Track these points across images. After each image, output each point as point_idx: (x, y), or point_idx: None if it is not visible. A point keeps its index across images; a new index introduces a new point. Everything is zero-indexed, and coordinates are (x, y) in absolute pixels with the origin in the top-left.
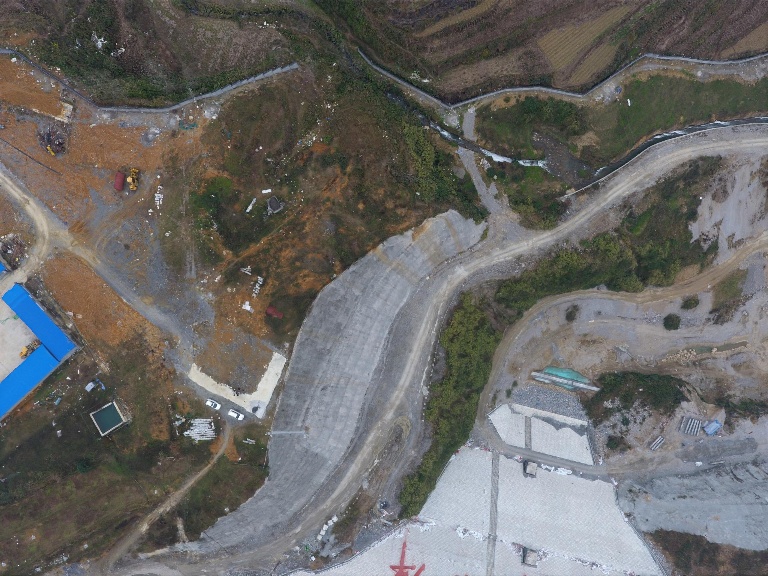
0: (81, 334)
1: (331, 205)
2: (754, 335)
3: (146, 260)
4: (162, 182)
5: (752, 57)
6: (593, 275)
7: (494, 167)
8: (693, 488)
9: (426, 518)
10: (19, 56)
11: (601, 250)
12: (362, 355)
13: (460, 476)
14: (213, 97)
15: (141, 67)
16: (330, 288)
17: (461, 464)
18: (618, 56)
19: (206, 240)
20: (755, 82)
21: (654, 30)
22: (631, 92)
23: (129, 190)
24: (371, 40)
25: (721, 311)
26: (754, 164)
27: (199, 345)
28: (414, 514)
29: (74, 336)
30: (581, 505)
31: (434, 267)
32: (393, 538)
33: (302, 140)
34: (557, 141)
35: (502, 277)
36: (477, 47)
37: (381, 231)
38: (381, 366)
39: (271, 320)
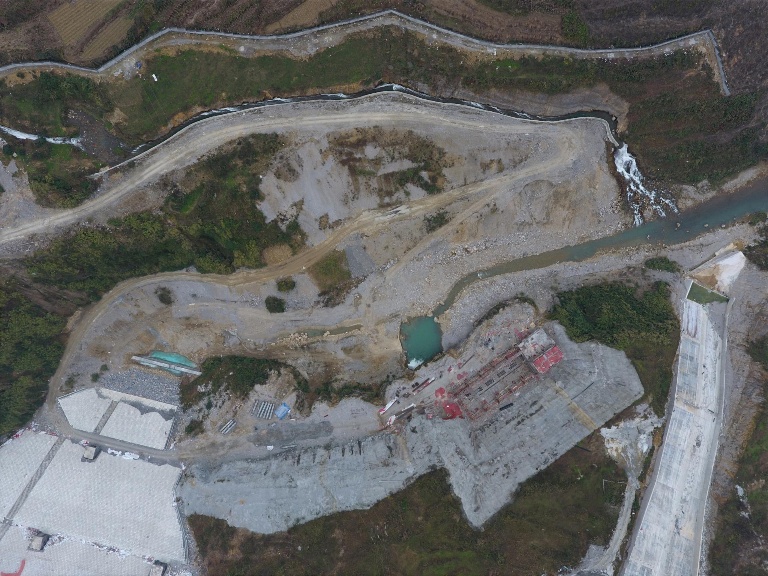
0: None
1: None
2: (368, 318)
3: None
4: None
5: (298, 32)
6: (154, 256)
7: (10, 144)
8: (251, 472)
9: None
10: None
11: (136, 229)
12: None
13: (6, 460)
14: None
15: None
16: None
17: (14, 448)
18: (128, 30)
19: None
20: (307, 57)
21: (177, 4)
22: (157, 67)
23: None
24: None
25: (331, 294)
26: (320, 142)
27: None
28: None
29: None
30: (131, 490)
31: None
32: None
33: None
34: (93, 118)
35: (14, 256)
36: None
37: None
38: None
39: None
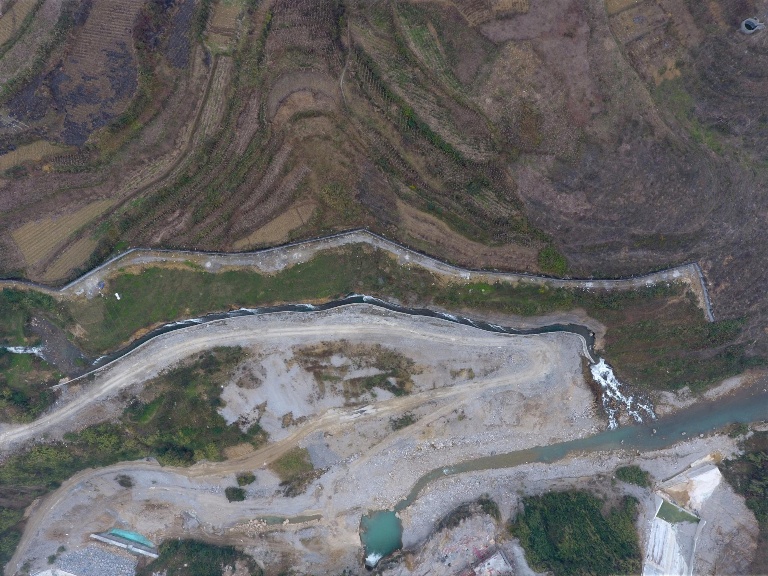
0: None
1: None
2: (328, 509)
3: None
4: None
5: (267, 249)
6: None
7: None
8: None
9: None
10: None
11: (92, 443)
12: None
13: None
14: None
15: None
16: None
17: None
18: (91, 254)
19: None
20: (275, 273)
21: (143, 224)
22: (120, 286)
23: None
24: None
25: (293, 483)
26: (285, 353)
27: None
28: None
29: None
30: None
31: None
32: None
33: None
34: (55, 327)
35: None
36: None
37: None
38: None
39: None
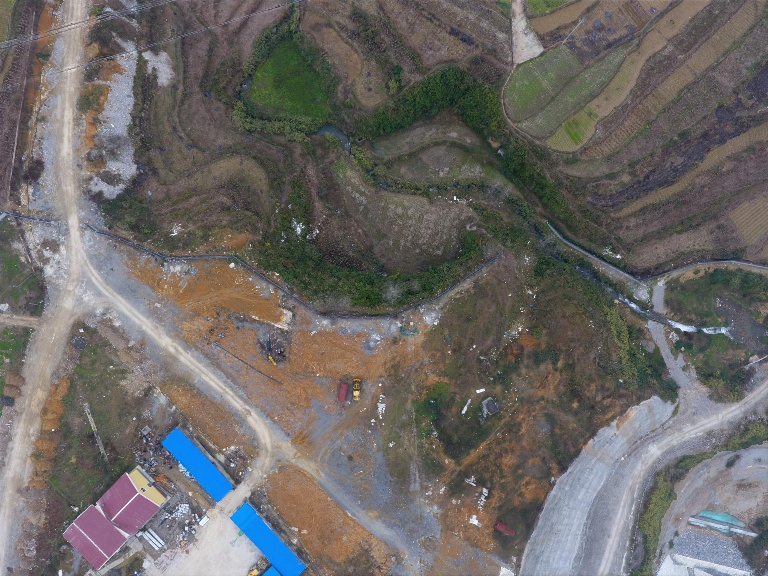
0: (306, 550)
1: (545, 404)
2: None
3: (370, 472)
4: (384, 391)
5: None
6: None
7: (683, 340)
8: None
9: None
10: (237, 261)
11: None
12: (566, 546)
13: None
14: (433, 301)
15: (338, 250)
16: (553, 496)
17: None
18: None
19: (429, 450)
20: None
21: None
22: None
23: (351, 399)
24: (567, 219)
25: None
26: None
27: (426, 560)
28: None
29: (300, 552)
30: None
31: (628, 447)
32: None
33: (509, 331)
34: (739, 307)
35: (693, 453)
36: (673, 225)
37: (591, 425)
38: (581, 553)
39: (502, 537)
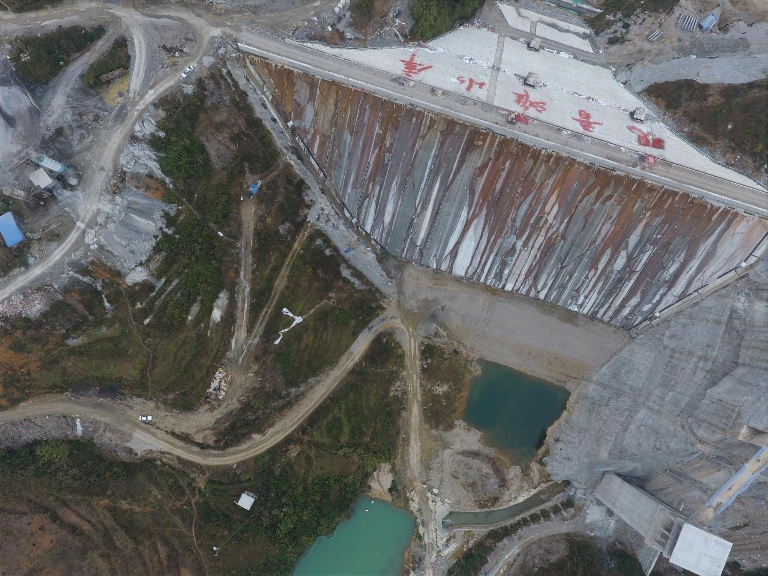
0: None
1: None
2: None
3: None
4: None
5: None
6: None
7: None
8: None
9: (435, 46)
10: None
11: None
12: None
13: (468, 36)
14: None
15: None
16: None
17: (469, 32)
18: None
19: None
20: None
21: None
22: None
23: None
24: None
25: None
26: None
27: None
28: (424, 36)
29: None
30: (580, 72)
31: None
32: (403, 50)
33: None
34: None
35: None
36: None
37: None
38: None
39: None
